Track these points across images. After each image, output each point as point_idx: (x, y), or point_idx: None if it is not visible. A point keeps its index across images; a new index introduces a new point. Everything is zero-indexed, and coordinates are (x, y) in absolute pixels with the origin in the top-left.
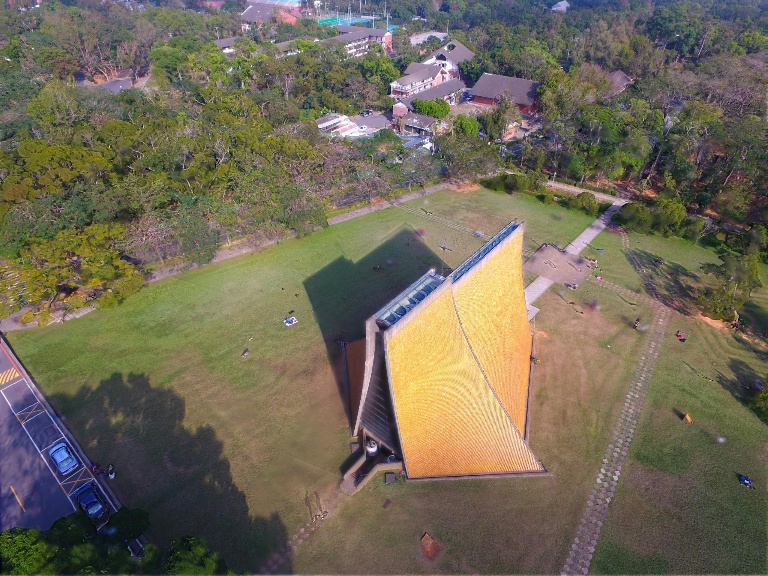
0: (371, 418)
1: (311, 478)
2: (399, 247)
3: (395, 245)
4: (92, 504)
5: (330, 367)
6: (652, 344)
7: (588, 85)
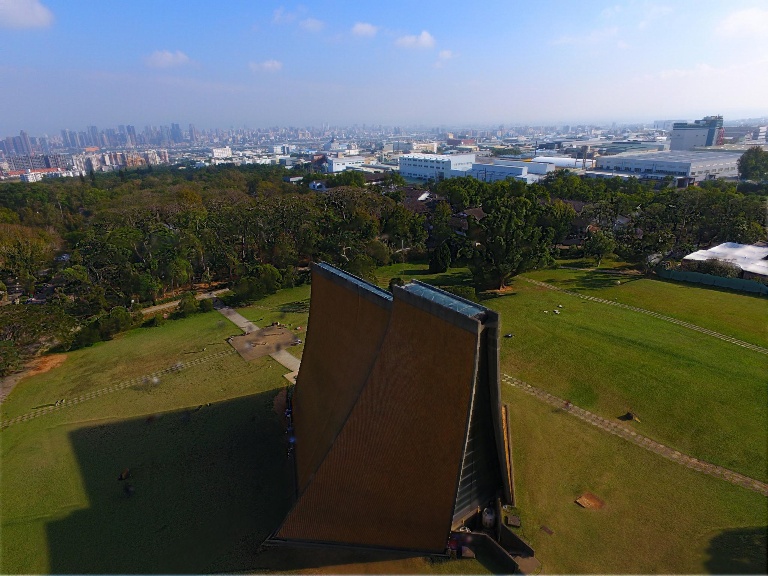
0: None
1: None
2: (101, 444)
3: (91, 447)
4: None
5: (308, 569)
6: None
7: None
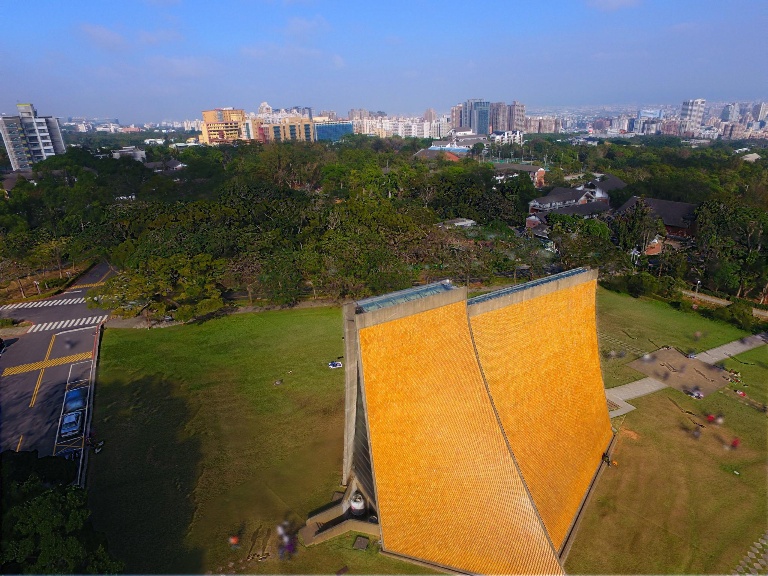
0: (360, 461)
1: (273, 513)
2: None
3: None
4: None
5: None
6: None
7: (762, 207)
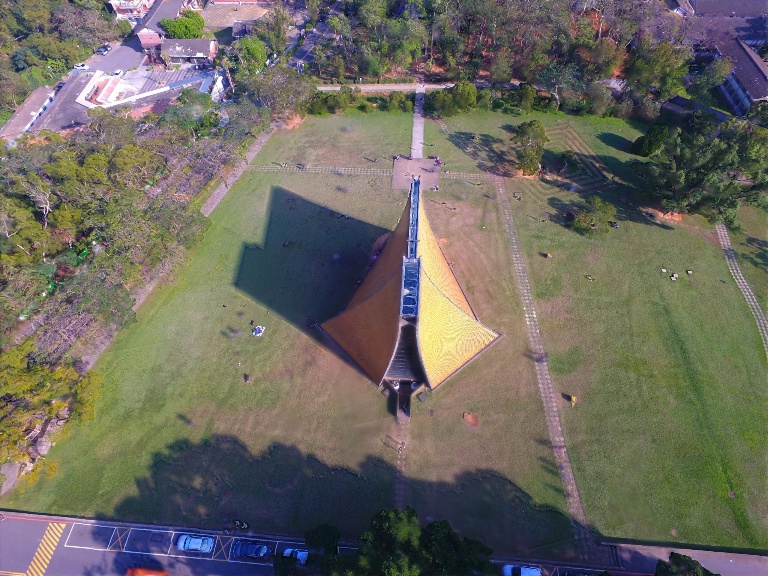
0: (391, 369)
1: (376, 430)
2: (287, 214)
3: (282, 214)
4: (259, 550)
5: (322, 349)
6: (506, 212)
7: None
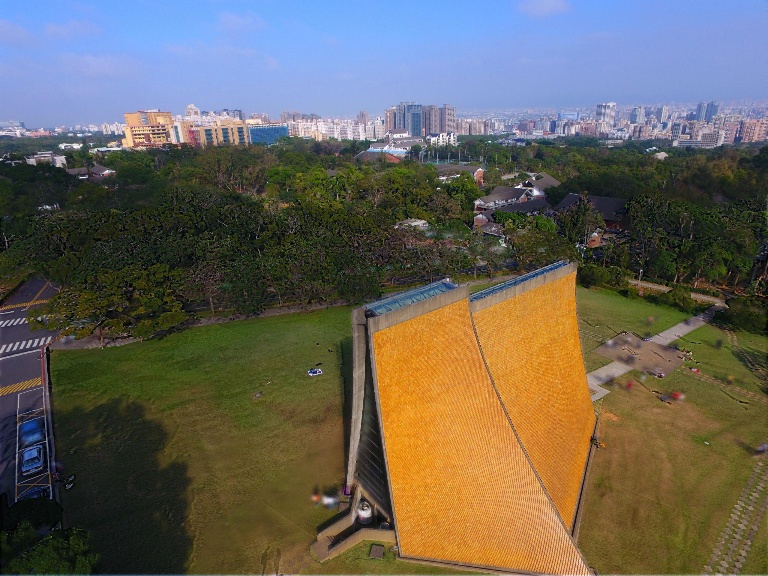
0: (366, 468)
1: (279, 532)
2: None
3: None
4: None
5: (342, 419)
6: None
7: None
